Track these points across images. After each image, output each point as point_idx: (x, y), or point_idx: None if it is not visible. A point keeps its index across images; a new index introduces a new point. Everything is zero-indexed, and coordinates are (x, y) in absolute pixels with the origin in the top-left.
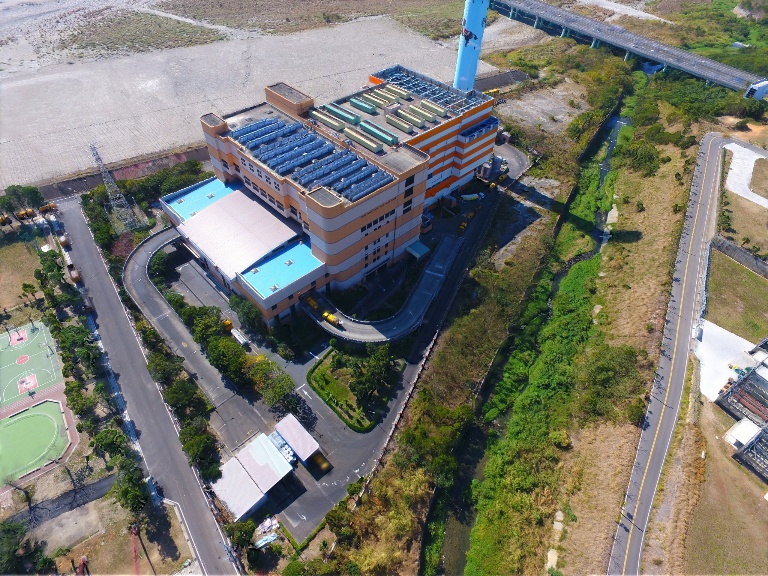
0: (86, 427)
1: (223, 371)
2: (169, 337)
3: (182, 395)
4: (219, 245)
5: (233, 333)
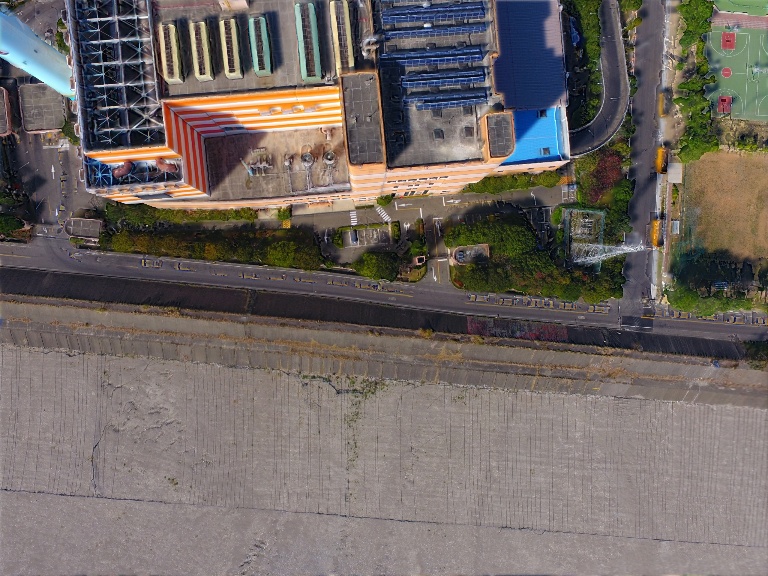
0: None
1: None
2: (612, 12)
3: None
4: (545, 33)
5: None
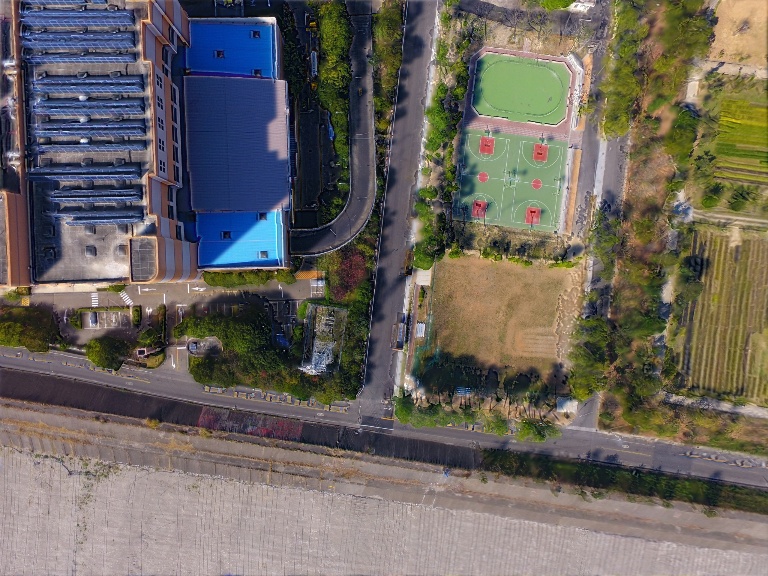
0: (464, 44)
1: (348, 21)
2: (368, 109)
3: (389, 18)
4: (267, 136)
5: (316, 69)
